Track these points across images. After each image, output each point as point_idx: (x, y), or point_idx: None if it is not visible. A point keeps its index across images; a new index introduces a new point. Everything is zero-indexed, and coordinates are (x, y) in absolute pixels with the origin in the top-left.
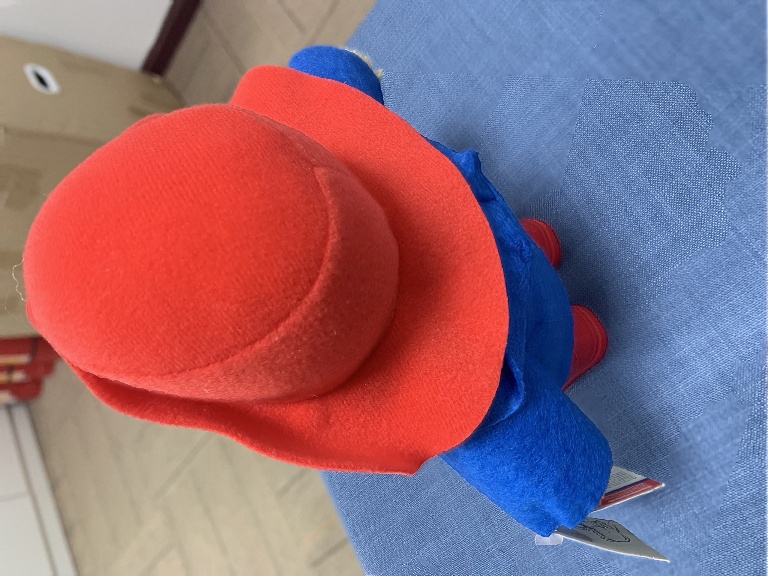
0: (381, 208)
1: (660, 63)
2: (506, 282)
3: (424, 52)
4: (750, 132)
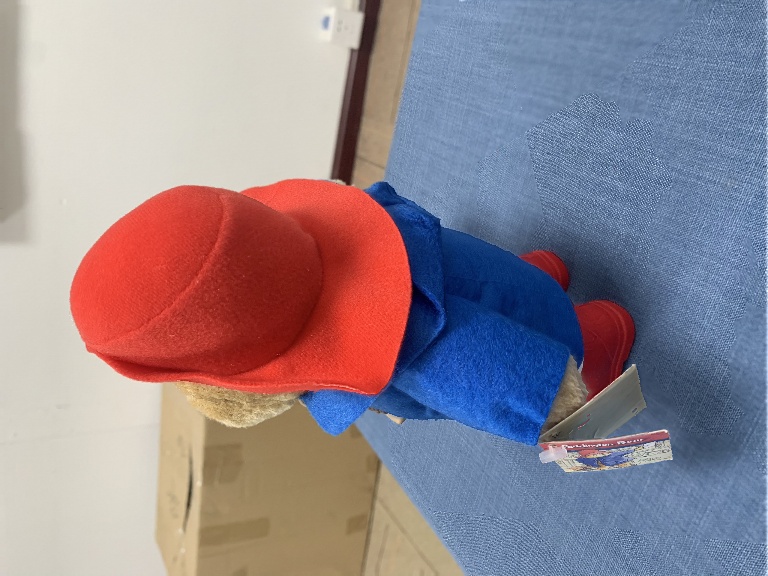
0: None
1: (565, 91)
2: (412, 243)
3: (422, 182)
4: (644, 95)
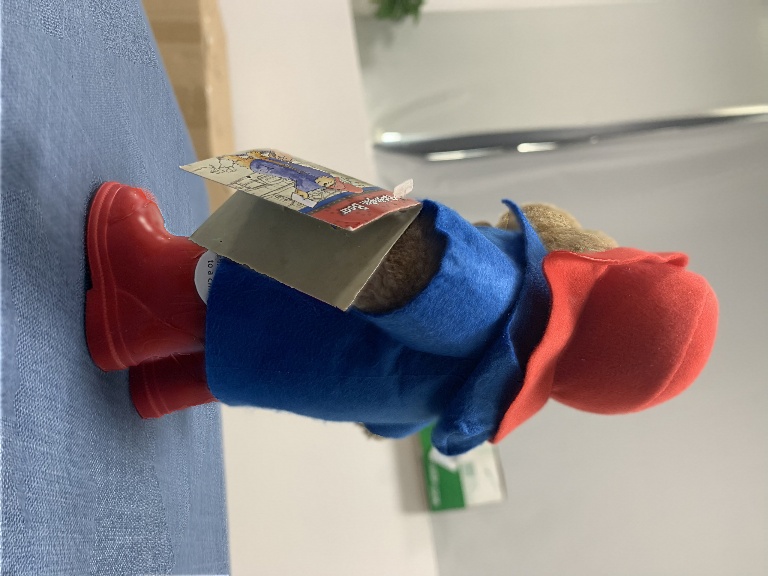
0: (567, 401)
1: None
2: (491, 403)
3: None
4: None
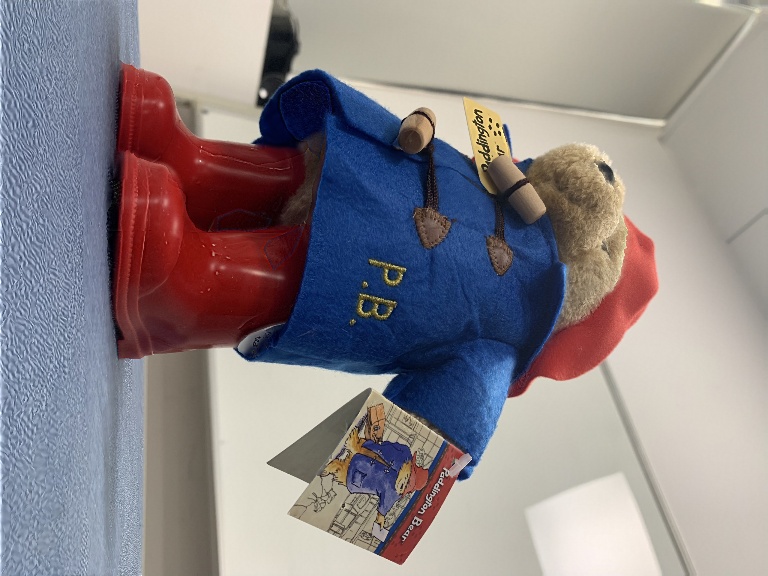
0: None
1: None
2: None
3: None
4: None
